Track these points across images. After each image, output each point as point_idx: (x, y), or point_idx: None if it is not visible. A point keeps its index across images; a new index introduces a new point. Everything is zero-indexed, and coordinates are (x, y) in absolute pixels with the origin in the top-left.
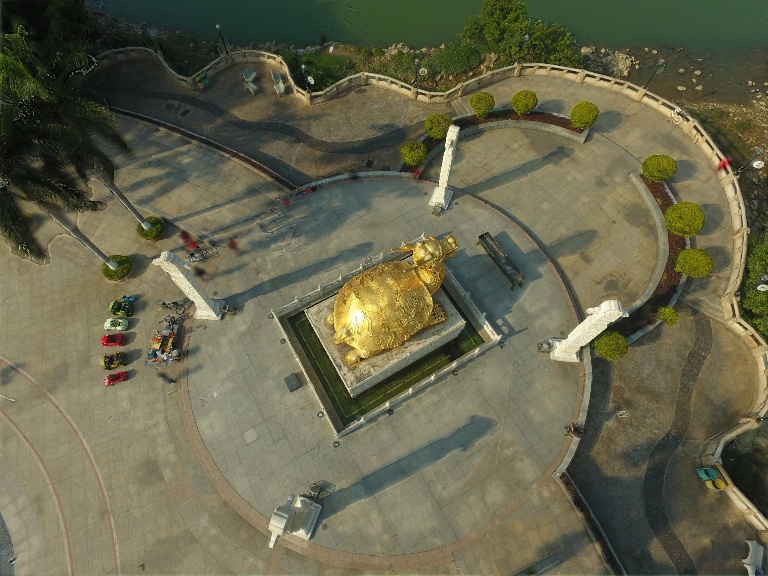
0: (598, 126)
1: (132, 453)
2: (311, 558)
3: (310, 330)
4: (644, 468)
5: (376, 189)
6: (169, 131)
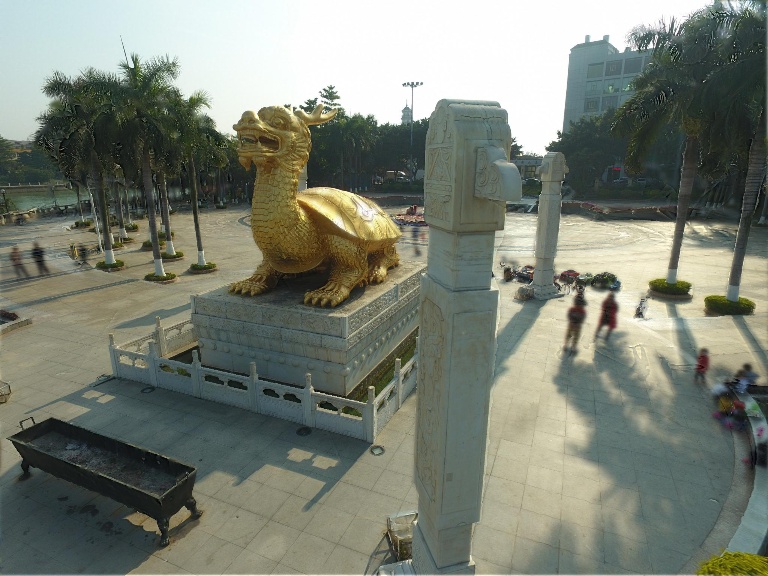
0: None
1: None
2: None
3: None
4: None
5: (658, 503)
6: None
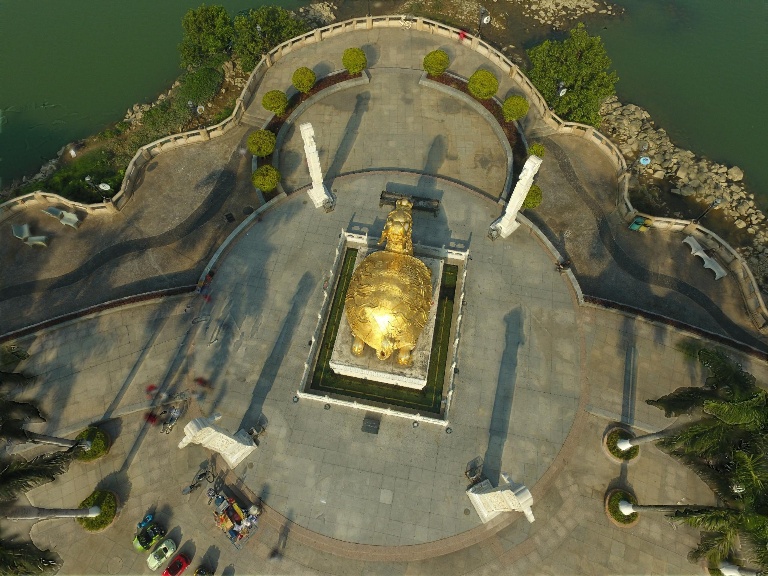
0: None
1: None
2: (518, 519)
3: (337, 378)
4: (608, 253)
5: (263, 231)
6: None
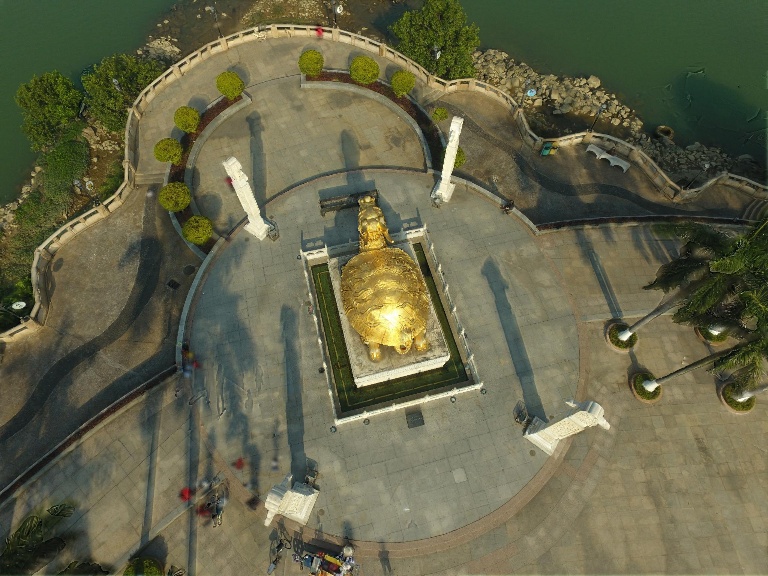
0: None
1: None
2: (574, 437)
3: (361, 392)
4: (535, 183)
5: (218, 283)
6: None
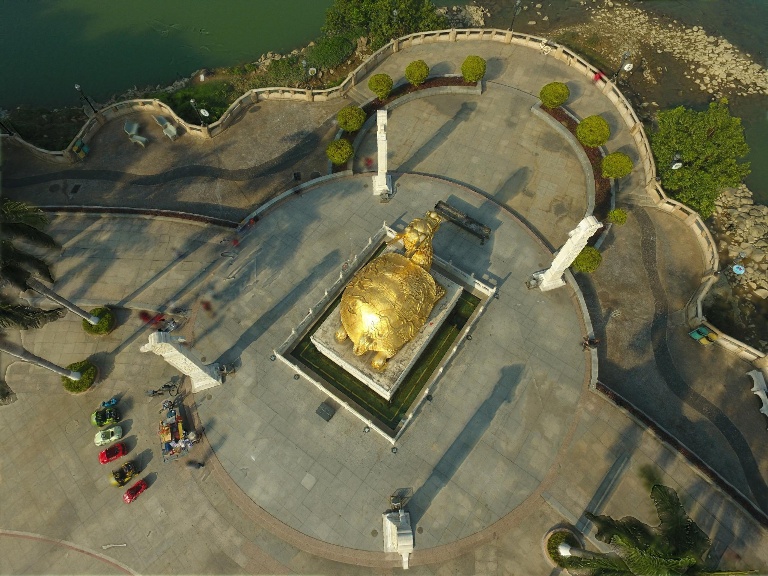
0: (486, 75)
1: (192, 557)
2: (421, 565)
3: (318, 355)
4: (651, 351)
5: (317, 198)
6: (69, 213)
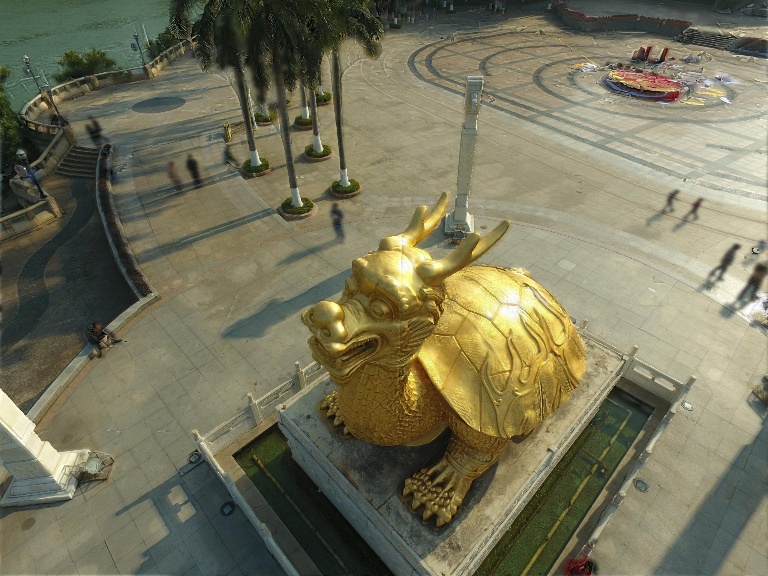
0: None
1: (680, 240)
2: None
3: None
4: (11, 351)
5: None
6: None
